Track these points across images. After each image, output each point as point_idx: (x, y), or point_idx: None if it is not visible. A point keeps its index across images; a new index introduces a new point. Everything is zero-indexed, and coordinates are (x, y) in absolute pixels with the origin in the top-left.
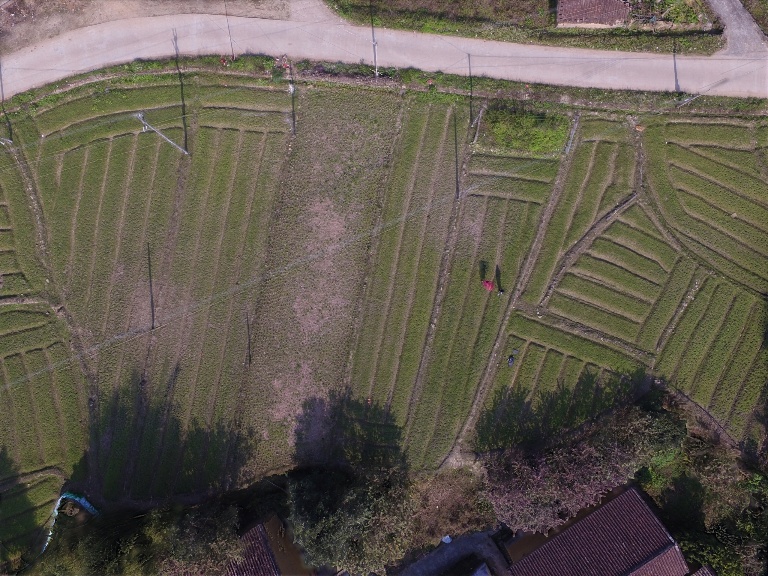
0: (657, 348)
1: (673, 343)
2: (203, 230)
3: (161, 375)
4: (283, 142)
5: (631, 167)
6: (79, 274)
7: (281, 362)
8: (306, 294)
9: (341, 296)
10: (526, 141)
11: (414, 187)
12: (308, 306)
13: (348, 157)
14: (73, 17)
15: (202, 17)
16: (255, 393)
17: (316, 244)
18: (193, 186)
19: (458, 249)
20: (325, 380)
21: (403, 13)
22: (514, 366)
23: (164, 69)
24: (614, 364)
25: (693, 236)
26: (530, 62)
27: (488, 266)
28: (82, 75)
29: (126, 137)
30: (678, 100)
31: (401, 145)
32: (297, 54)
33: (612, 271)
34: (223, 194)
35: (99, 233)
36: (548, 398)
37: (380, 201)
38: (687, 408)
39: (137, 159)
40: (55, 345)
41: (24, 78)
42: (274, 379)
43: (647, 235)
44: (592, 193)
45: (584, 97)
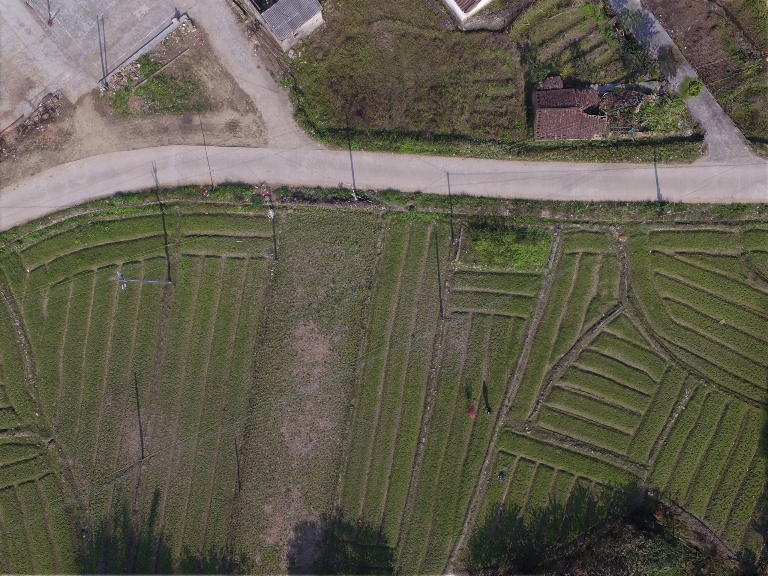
0: (649, 459)
1: (665, 454)
2: (189, 358)
3: (152, 504)
4: (265, 267)
5: (616, 278)
6: (68, 406)
7: (271, 487)
8: (293, 418)
9: (328, 419)
10: (508, 257)
11: (398, 306)
12: (296, 430)
13: (330, 279)
14: (54, 154)
15: (181, 148)
16: (246, 519)
17: (302, 368)
18: (177, 315)
19: (444, 367)
20: (315, 503)
21: (380, 135)
22: (504, 483)
23: (145, 202)
24: (606, 477)
25: (681, 345)
26: (509, 178)
27: (475, 383)
28: (64, 211)
29: (110, 269)
30: (661, 210)
31: (383, 265)
32: (276, 181)
33: (600, 383)
34: (207, 322)
35: (86, 365)
36: (540, 514)
37: (364, 322)
38: (682, 519)
39: (121, 290)
40: (47, 477)
41: (8, 216)
42: (264, 504)
43: (634, 346)
44: (577, 306)
45: (565, 210)
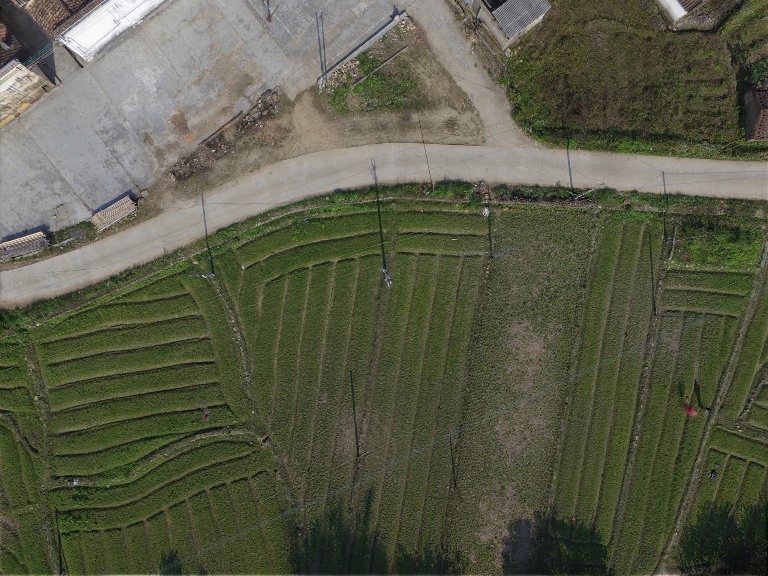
0: None
1: None
2: (404, 356)
3: (367, 502)
4: (480, 265)
5: None
6: (283, 404)
7: (485, 485)
8: (508, 416)
9: (543, 417)
10: (722, 256)
11: (611, 305)
12: (510, 428)
13: (545, 278)
14: (273, 151)
15: (400, 146)
16: (461, 517)
17: (516, 366)
18: (393, 312)
19: (657, 365)
20: (530, 501)
21: (598, 134)
22: (716, 480)
23: (364, 199)
24: None
25: None
26: (723, 177)
27: (687, 382)
28: (284, 208)
29: (326, 266)
30: None
31: (597, 264)
32: (494, 179)
33: None
34: (423, 319)
35: (301, 362)
36: (751, 511)
37: (578, 321)
38: None
39: (337, 287)
40: (260, 475)
41: (226, 213)
42: (479, 502)
43: None
44: None
45: None
